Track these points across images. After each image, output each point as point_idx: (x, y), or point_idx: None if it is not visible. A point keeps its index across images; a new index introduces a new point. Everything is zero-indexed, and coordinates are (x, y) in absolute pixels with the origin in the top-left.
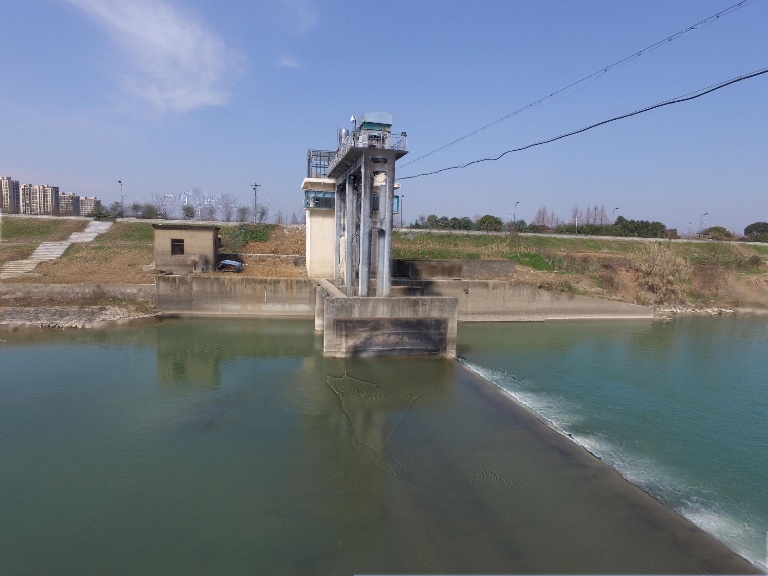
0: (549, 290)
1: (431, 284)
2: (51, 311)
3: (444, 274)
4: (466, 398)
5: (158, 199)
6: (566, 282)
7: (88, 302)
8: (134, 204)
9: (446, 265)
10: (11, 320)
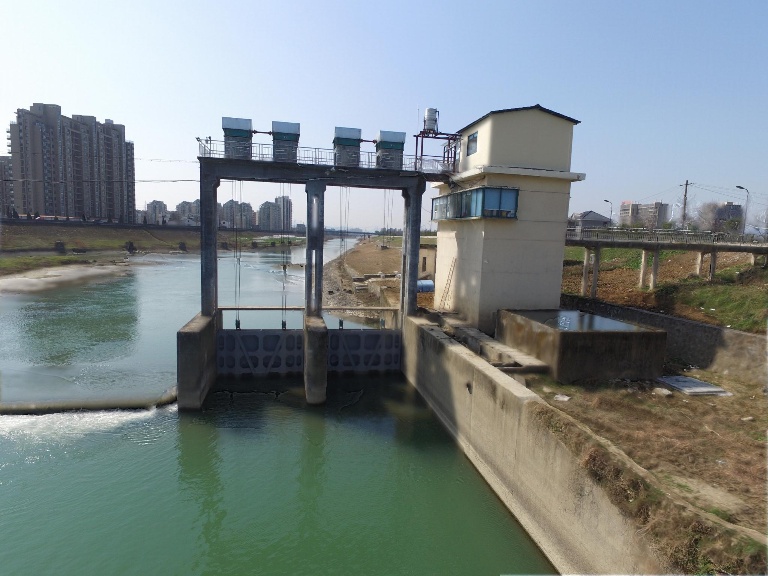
0: (630, 516)
1: (443, 350)
2: (349, 301)
3: (532, 348)
4: (35, 393)
5: (645, 216)
6: (736, 545)
7: (370, 300)
8: (622, 224)
9: (535, 328)
10: (334, 302)
